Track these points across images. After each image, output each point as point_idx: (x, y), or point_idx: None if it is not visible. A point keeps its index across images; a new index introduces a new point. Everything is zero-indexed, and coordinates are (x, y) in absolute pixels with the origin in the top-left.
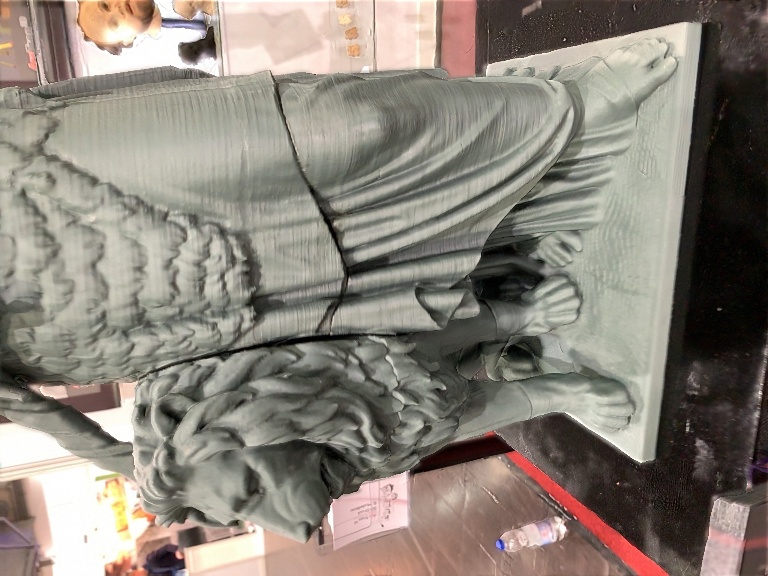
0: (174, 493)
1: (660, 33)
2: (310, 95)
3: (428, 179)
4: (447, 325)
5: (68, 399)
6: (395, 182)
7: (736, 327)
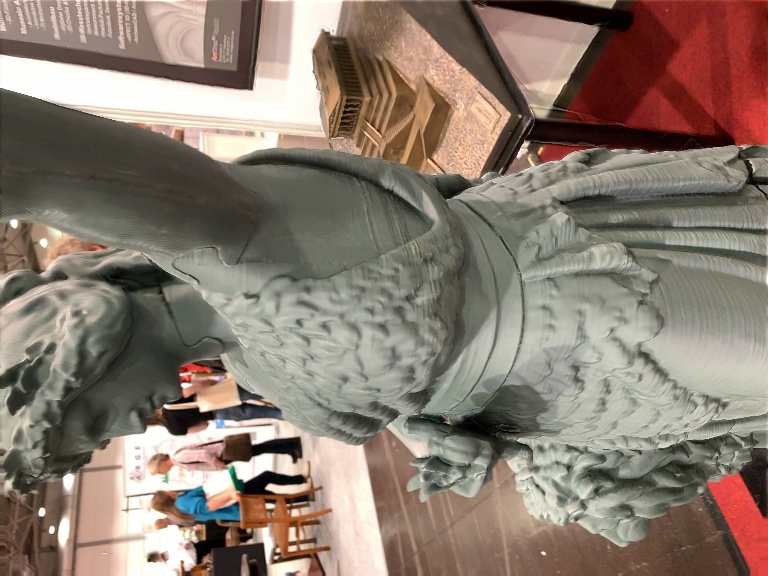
0: None
1: None
2: None
3: None
4: None
5: (204, 70)
6: None
7: None
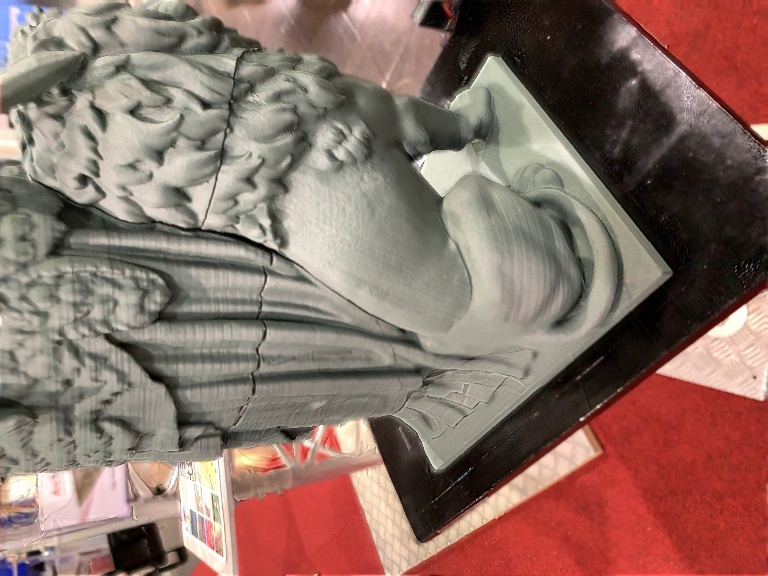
0: None
1: None
2: None
3: None
4: None
5: None
6: None
7: None
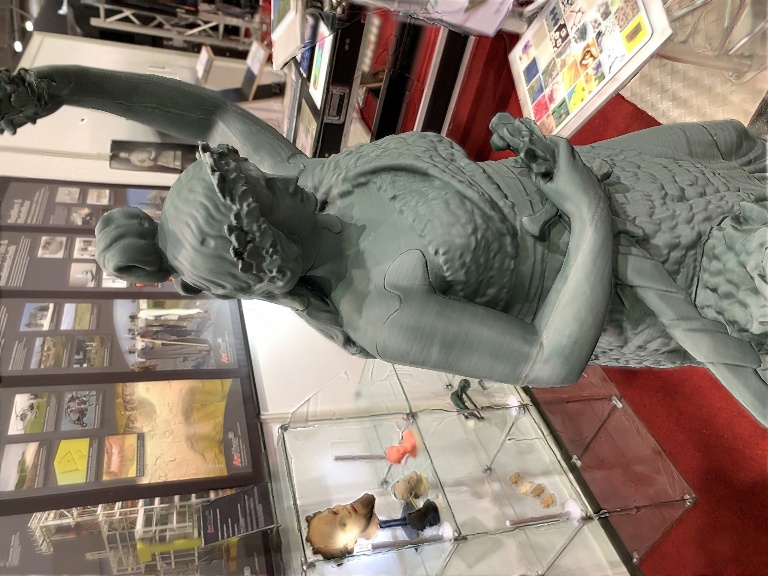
0: None
1: None
2: None
3: None
4: None
5: None
6: (762, 162)
7: None
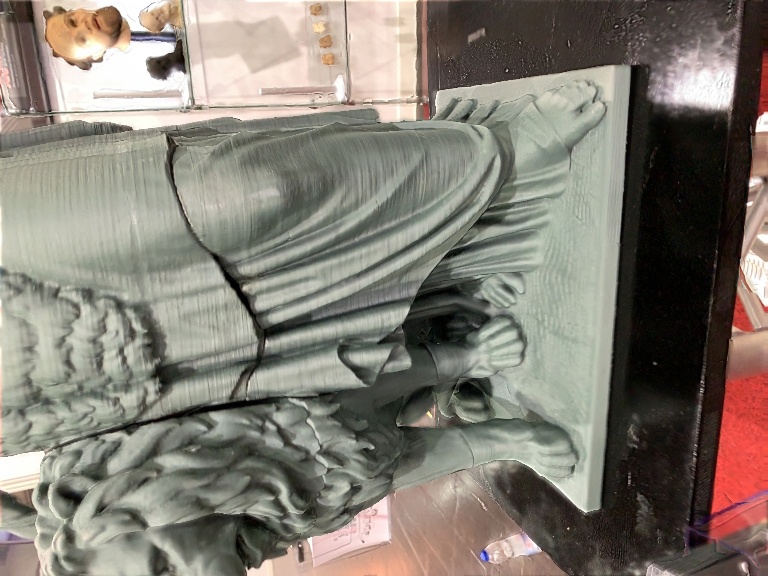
0: (77, 575)
1: (589, 75)
2: (204, 162)
3: (344, 237)
4: (380, 377)
5: None
6: (307, 243)
7: (671, 384)
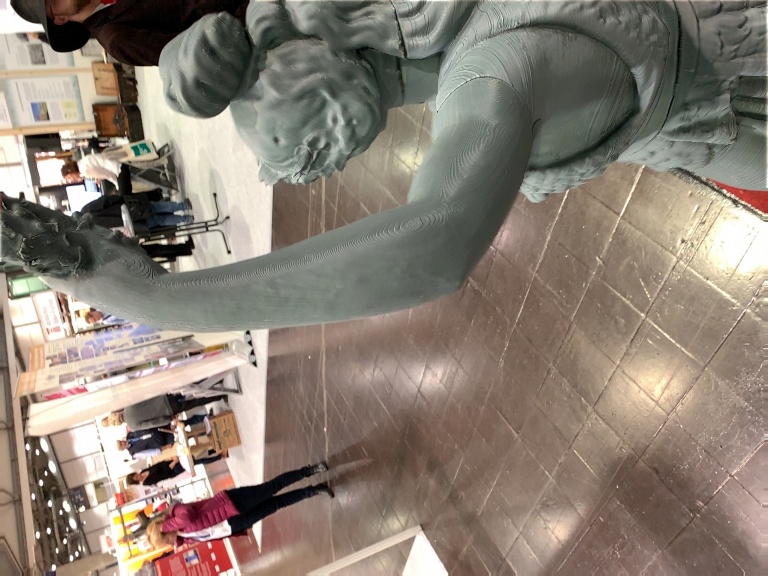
0: None
1: None
2: None
3: None
4: None
5: None
6: None
7: None
